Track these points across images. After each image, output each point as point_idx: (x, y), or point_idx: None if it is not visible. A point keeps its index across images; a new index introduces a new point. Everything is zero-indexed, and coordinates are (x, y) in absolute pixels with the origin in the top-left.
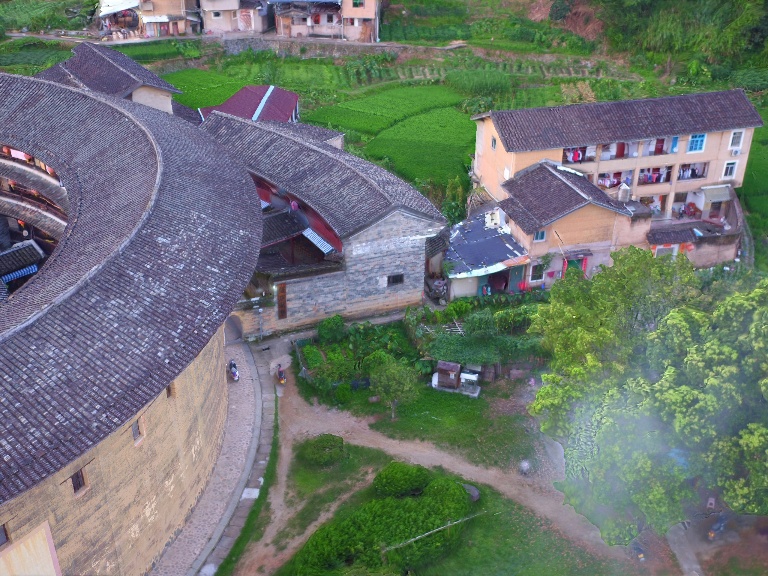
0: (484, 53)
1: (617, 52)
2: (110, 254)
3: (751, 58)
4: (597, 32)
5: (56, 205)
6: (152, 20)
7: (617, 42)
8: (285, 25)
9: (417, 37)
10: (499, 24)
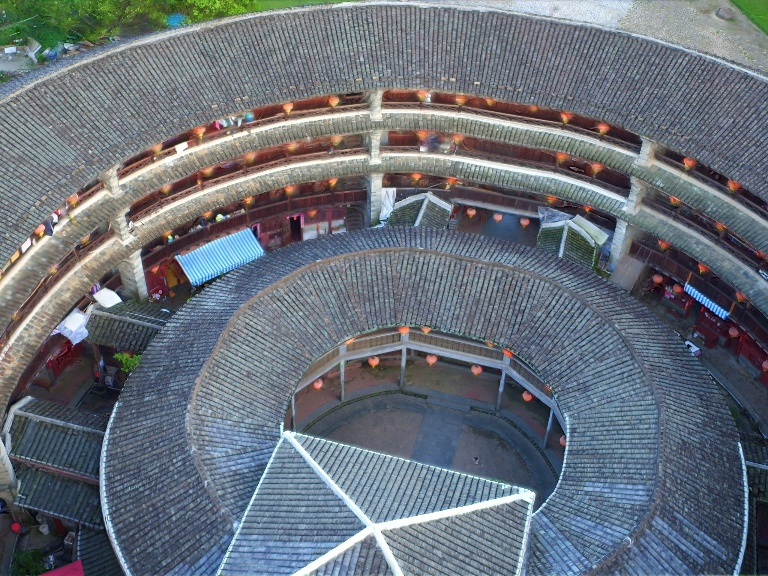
0: None
1: None
2: (322, 5)
3: None
4: None
5: None
6: None
7: None
8: None
9: None
10: None
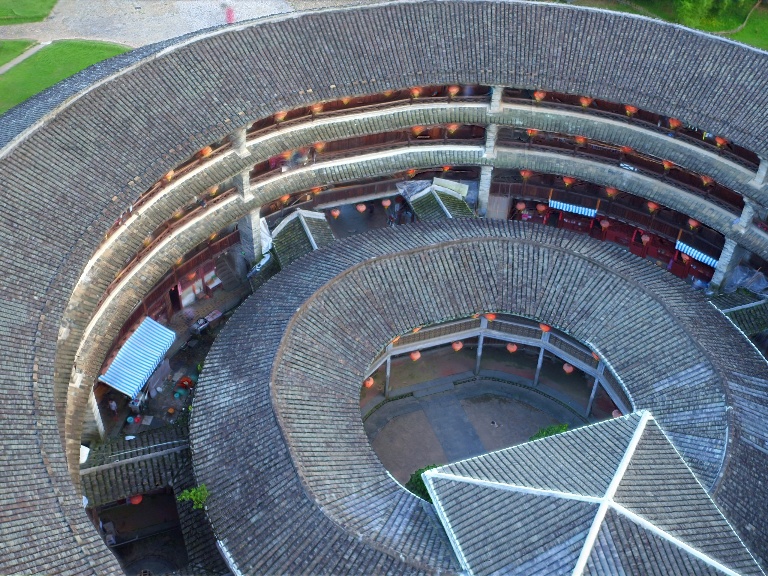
0: None
1: None
2: (146, 58)
3: None
4: None
5: None
6: None
7: None
8: None
9: None
10: None
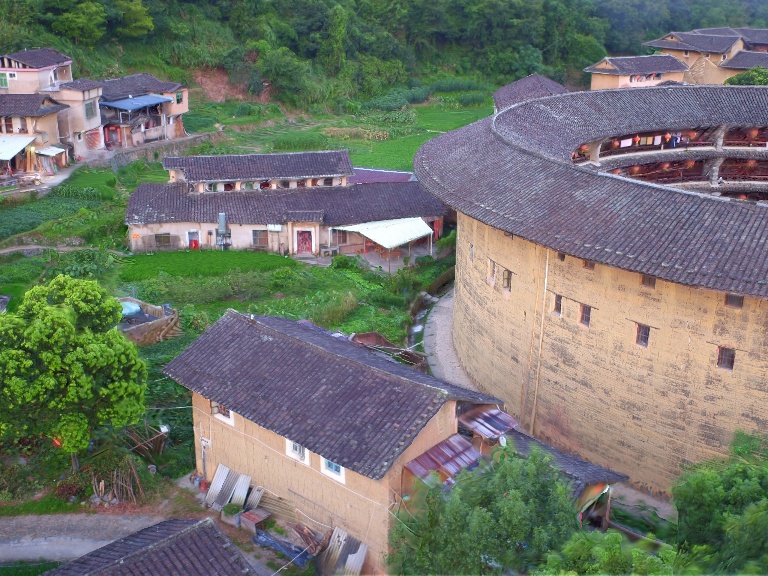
0: (240, 129)
1: (295, 110)
2: None
3: (360, 95)
4: (269, 100)
5: (651, 172)
6: (54, 152)
7: (294, 102)
8: (128, 135)
9: (198, 126)
10: (213, 108)
